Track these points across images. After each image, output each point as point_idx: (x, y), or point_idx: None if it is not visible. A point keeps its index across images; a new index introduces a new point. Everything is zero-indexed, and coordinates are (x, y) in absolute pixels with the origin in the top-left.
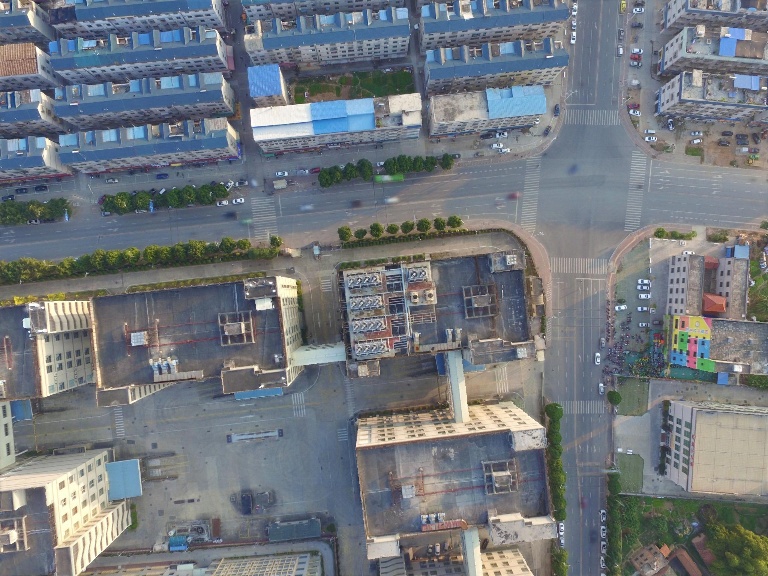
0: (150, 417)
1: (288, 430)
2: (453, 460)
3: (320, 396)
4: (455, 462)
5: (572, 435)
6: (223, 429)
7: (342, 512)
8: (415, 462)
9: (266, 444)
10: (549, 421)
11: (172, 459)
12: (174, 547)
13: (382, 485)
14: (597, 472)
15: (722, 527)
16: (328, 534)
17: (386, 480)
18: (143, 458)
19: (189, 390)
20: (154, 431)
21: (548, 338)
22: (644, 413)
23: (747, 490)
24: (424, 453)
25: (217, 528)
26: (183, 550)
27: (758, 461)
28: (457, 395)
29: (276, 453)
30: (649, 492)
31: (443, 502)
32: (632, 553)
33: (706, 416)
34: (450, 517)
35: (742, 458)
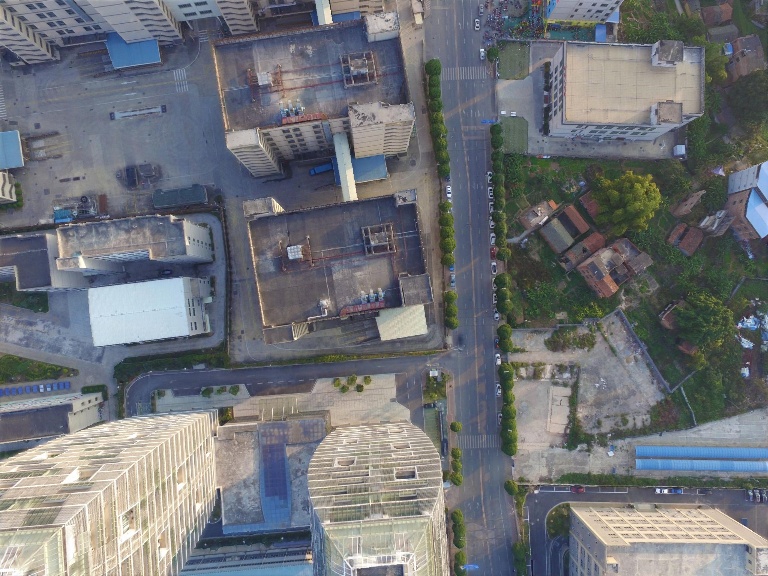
0: (32, 98)
1: (171, 106)
2: (311, 57)
3: (202, 71)
4: (313, 58)
5: (456, 101)
6: (106, 107)
7: (229, 184)
8: (273, 59)
9: (150, 120)
10: (428, 78)
11: (56, 139)
12: (59, 220)
13: (241, 82)
14: (482, 136)
15: (607, 180)
16: (216, 205)
17: (245, 77)
18: (26, 139)
19: (70, 70)
20: (36, 111)
21: (427, 7)
22: (526, 76)
23: (622, 120)
24: (282, 51)
25: (104, 203)
26: (68, 222)
27: (631, 91)
28: (322, 20)
29: (160, 129)
30: (535, 153)
31: (303, 98)
32: (520, 213)
33: (577, 49)
34: (311, 113)
35: (615, 89)
